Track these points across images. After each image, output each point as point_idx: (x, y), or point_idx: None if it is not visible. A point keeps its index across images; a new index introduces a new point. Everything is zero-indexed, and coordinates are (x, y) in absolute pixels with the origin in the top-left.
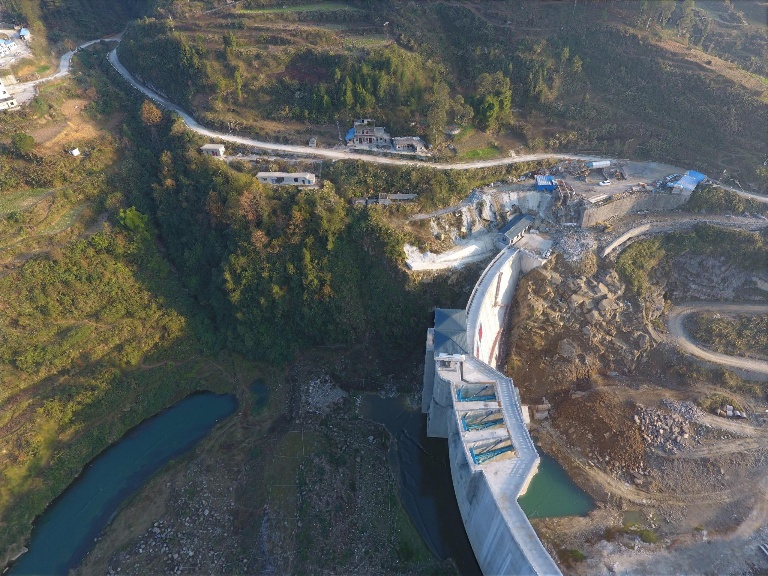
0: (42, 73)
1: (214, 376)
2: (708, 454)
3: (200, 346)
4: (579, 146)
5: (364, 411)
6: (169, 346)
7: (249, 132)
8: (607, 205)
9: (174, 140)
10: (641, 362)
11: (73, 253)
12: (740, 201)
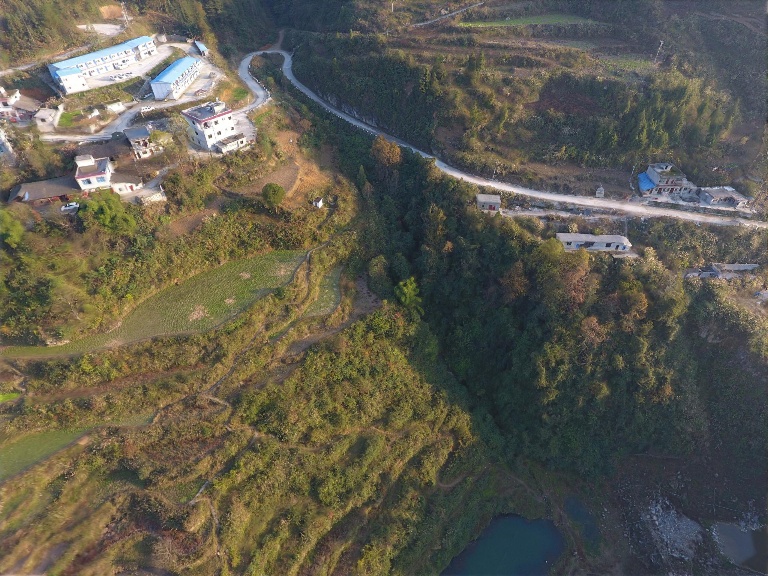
0: (245, 99)
1: (519, 494)
2: None
3: (491, 452)
4: None
5: (730, 552)
6: (466, 457)
7: (520, 178)
8: None
9: (426, 186)
10: None
11: (354, 341)
12: None
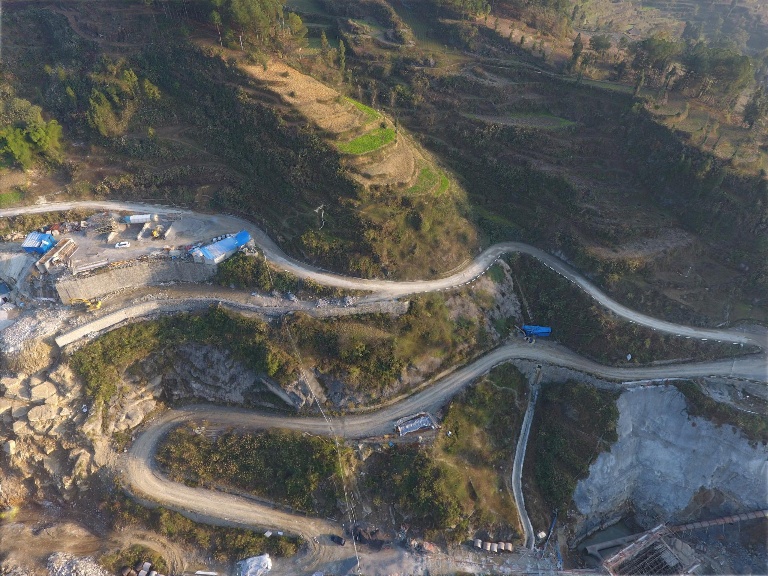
0: None
1: None
2: None
3: None
4: (135, 193)
5: None
6: None
7: None
8: (96, 276)
9: None
10: (79, 491)
11: None
12: (271, 276)
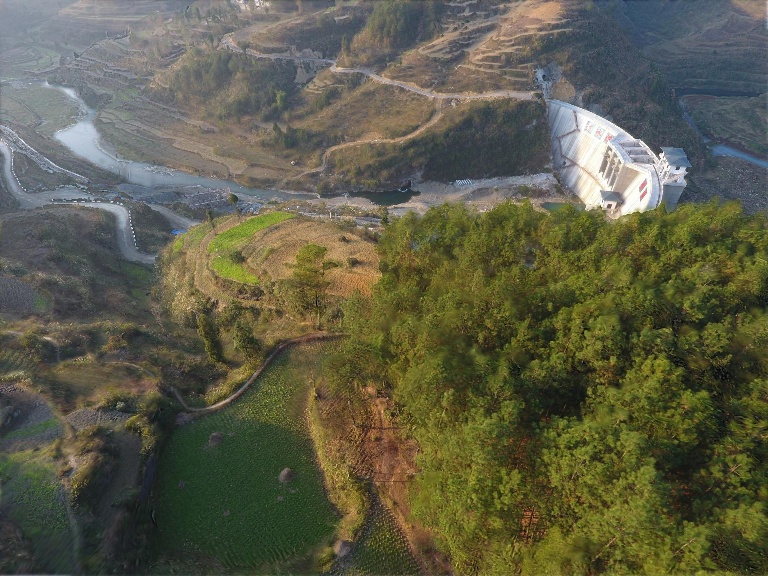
0: None
1: None
2: (472, 208)
3: None
4: None
5: None
6: None
7: None
8: None
9: None
10: None
11: None
12: None
